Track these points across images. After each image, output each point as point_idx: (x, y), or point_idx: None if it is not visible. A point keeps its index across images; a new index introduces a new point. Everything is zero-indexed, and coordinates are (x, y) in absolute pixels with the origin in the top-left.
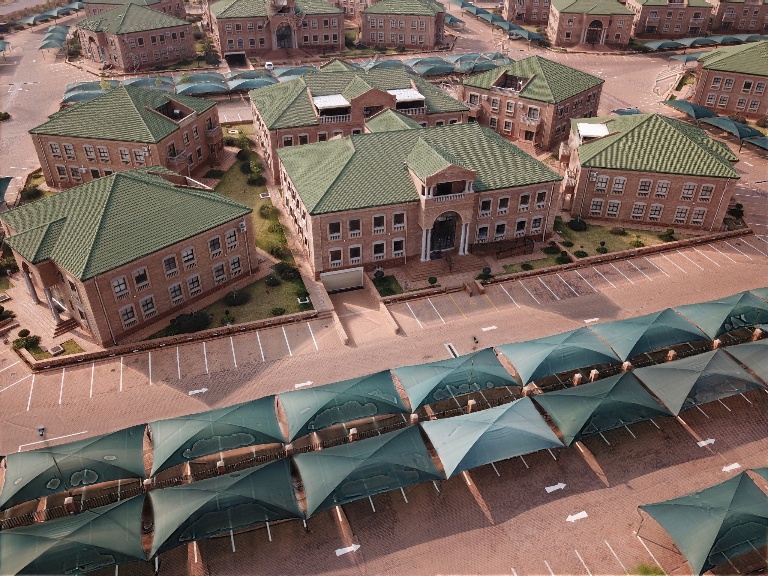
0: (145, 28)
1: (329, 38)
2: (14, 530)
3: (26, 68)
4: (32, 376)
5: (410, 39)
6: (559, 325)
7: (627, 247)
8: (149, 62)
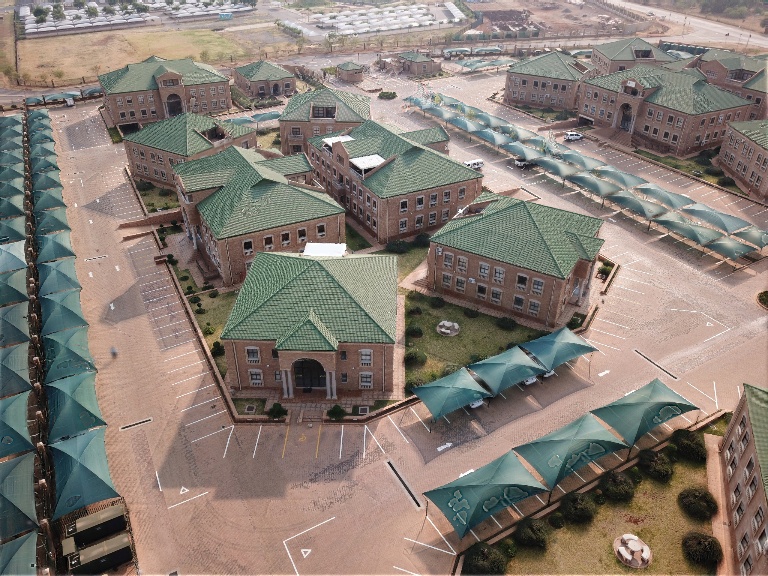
0: (532, 73)
1: (669, 137)
2: (21, 179)
3: (489, 80)
4: (122, 169)
5: (750, 175)
6: (111, 293)
7: (205, 325)
8: (526, 100)
